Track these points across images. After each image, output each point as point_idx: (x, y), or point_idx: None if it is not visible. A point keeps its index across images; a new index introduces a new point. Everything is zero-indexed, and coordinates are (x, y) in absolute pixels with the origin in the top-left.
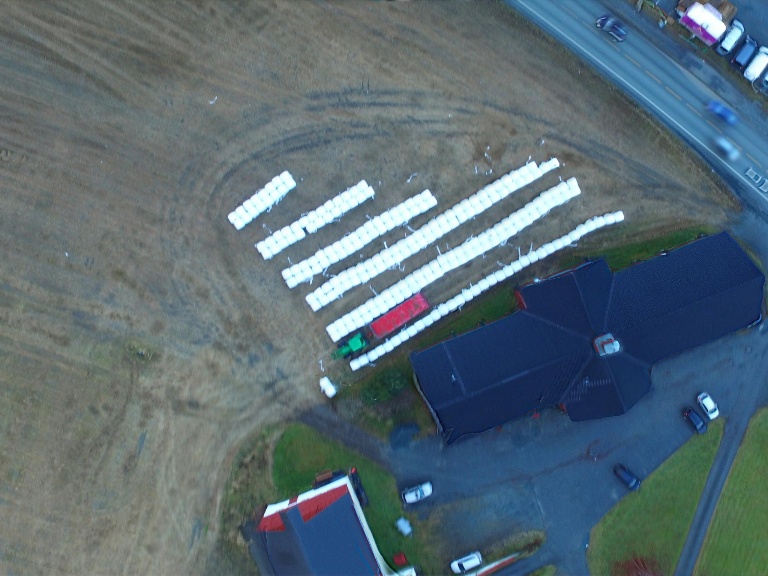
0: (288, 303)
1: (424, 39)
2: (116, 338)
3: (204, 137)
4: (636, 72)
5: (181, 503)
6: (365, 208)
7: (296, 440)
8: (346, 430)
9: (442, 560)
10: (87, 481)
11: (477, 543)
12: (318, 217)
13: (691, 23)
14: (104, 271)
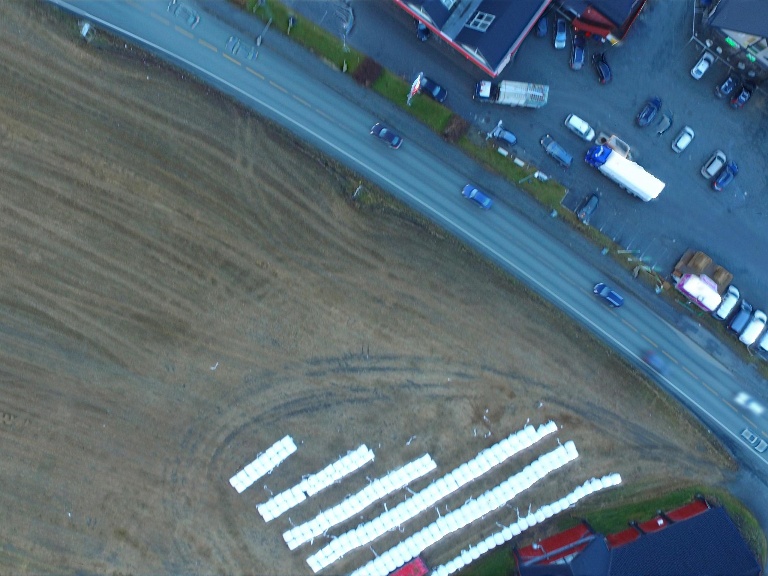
0: (289, 563)
1: (423, 305)
2: None
3: (205, 402)
4: (633, 336)
5: None
6: (365, 470)
7: None
8: None
9: None
10: None
11: None
12: (319, 481)
13: (687, 293)
14: (107, 531)
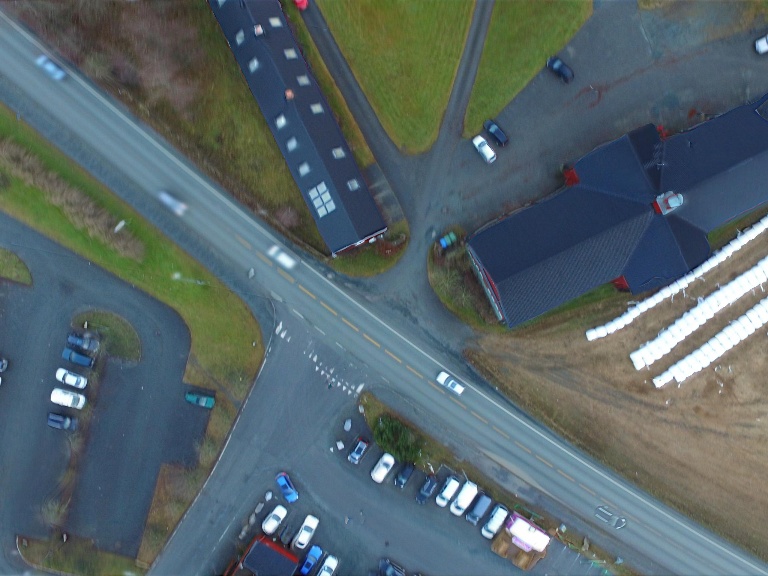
0: None
1: None
2: None
3: None
4: (584, 479)
5: None
6: None
7: None
8: None
9: None
10: None
11: None
12: None
13: None
14: None
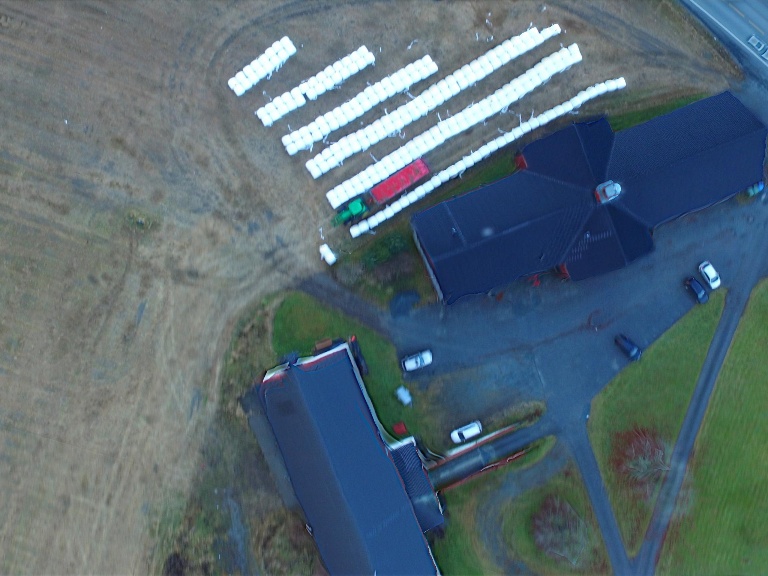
0: (288, 171)
1: None
2: (115, 207)
3: (204, 3)
4: None
5: (180, 373)
6: (365, 75)
7: (296, 308)
8: (346, 298)
9: (442, 430)
10: (86, 351)
11: (477, 413)
12: (318, 83)
13: None
14: (104, 139)
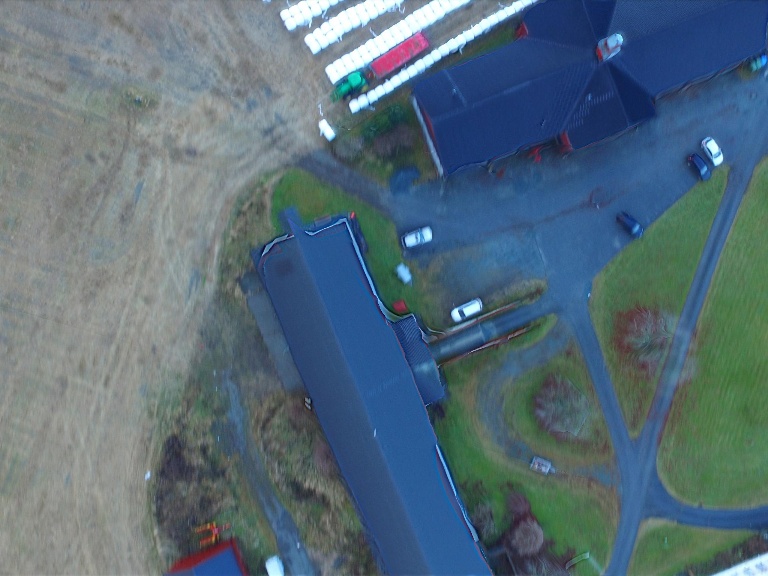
0: (287, 47)
1: None
2: (113, 85)
3: None
4: None
5: (178, 253)
6: None
7: (295, 185)
8: (345, 175)
9: (442, 309)
10: (83, 230)
11: (478, 291)
12: None
13: None
14: (101, 15)
